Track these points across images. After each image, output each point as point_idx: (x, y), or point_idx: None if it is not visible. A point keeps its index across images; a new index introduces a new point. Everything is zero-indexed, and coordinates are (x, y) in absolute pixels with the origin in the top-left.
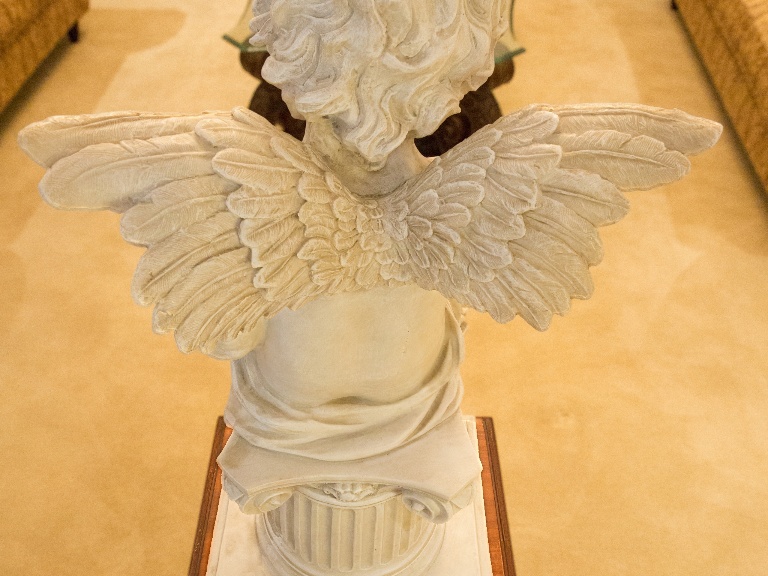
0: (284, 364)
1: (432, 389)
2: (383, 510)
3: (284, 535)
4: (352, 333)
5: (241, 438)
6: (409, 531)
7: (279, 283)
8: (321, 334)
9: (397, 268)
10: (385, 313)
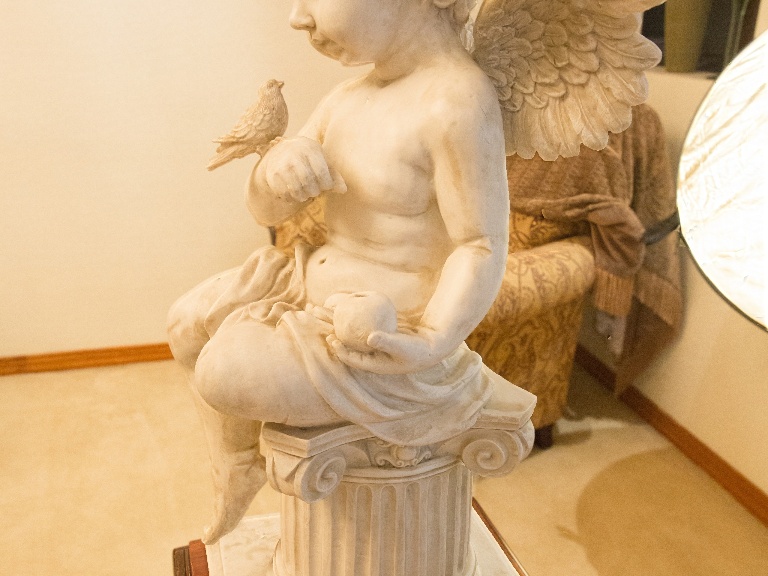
0: None
1: None
2: None
3: (456, 569)
4: None
5: (486, 407)
6: None
7: None
8: None
9: None
10: None
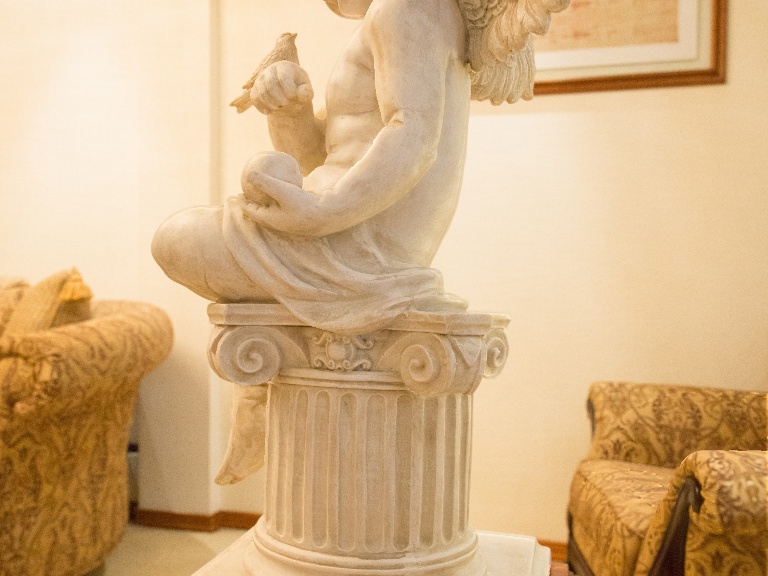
0: (449, 170)
1: None
2: None
3: (416, 534)
4: None
5: None
6: None
7: None
8: None
9: None
10: None
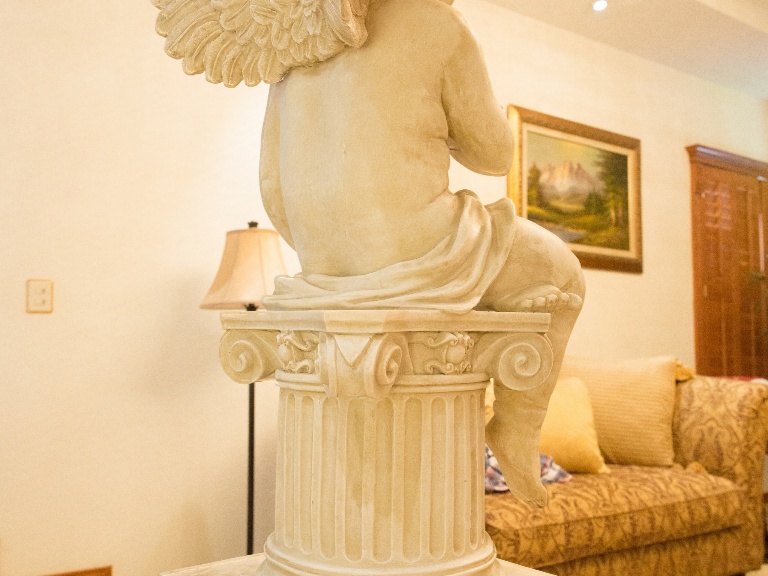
0: None
1: (406, 265)
2: (321, 414)
3: None
4: (310, 126)
5: None
6: (361, 509)
7: (225, 4)
8: (289, 124)
9: (316, 19)
10: (329, 98)
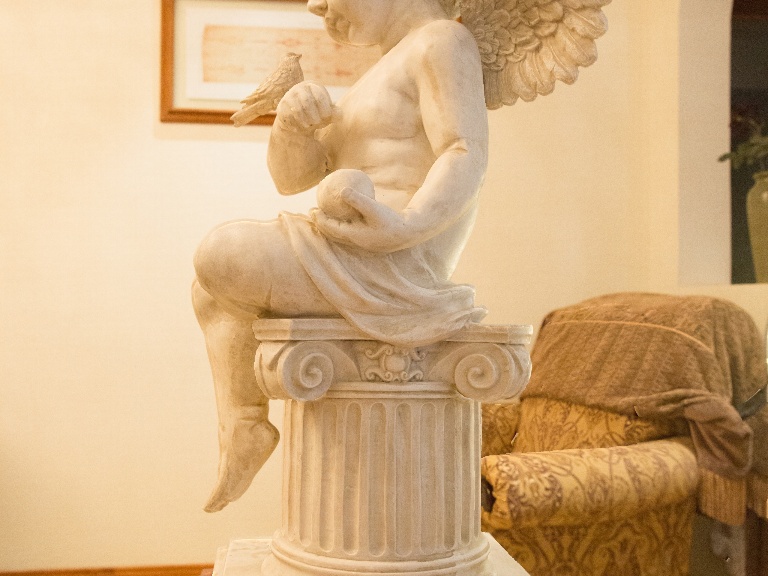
0: None
1: None
2: None
3: (459, 533)
4: None
5: None
6: None
7: None
8: None
9: None
10: None
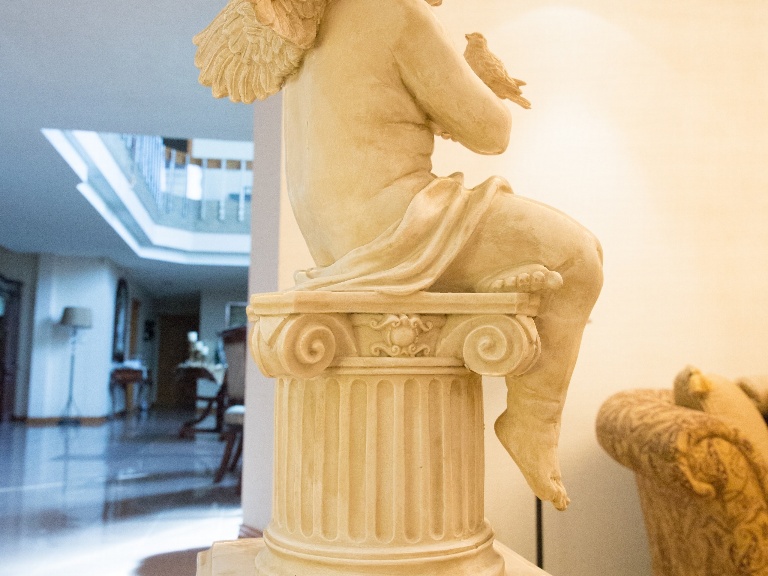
0: None
1: (359, 250)
2: (288, 395)
3: None
4: (294, 128)
5: None
6: (313, 487)
7: (229, 31)
8: None
9: None
10: None
